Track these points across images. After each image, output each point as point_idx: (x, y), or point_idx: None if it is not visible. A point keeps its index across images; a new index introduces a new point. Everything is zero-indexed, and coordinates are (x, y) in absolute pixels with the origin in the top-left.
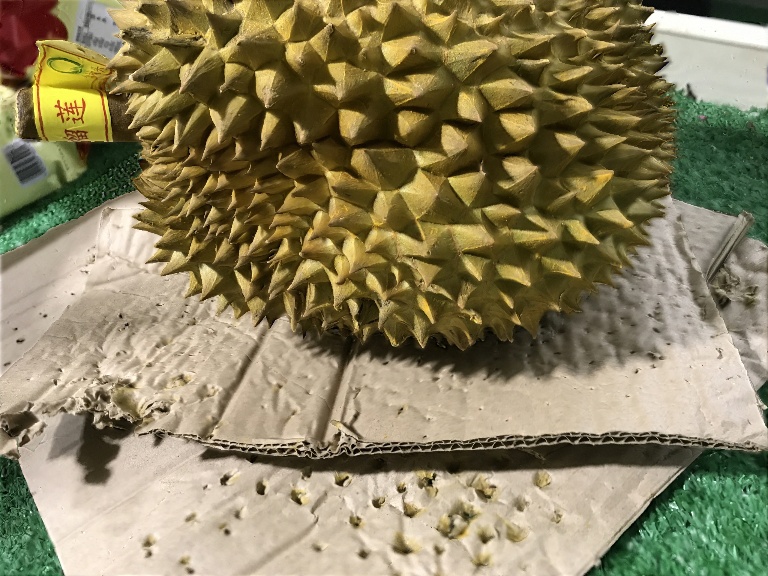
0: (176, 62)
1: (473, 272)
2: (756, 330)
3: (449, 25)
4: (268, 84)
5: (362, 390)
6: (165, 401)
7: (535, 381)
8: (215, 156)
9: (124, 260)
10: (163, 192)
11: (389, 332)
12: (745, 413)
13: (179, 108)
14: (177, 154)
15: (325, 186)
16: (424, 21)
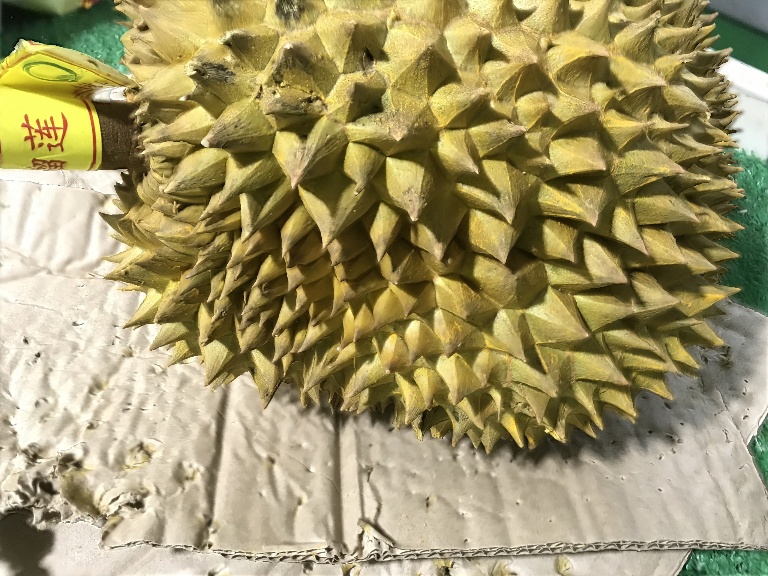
0: (270, 124)
1: (584, 403)
2: (733, 395)
3: (633, 133)
4: (415, 186)
5: (375, 469)
6: (135, 492)
7: (565, 466)
8: (295, 247)
9: (15, 253)
10: (177, 256)
11: (435, 425)
12: (761, 509)
13: (261, 185)
14: (228, 228)
15: (432, 295)
16: (602, 120)
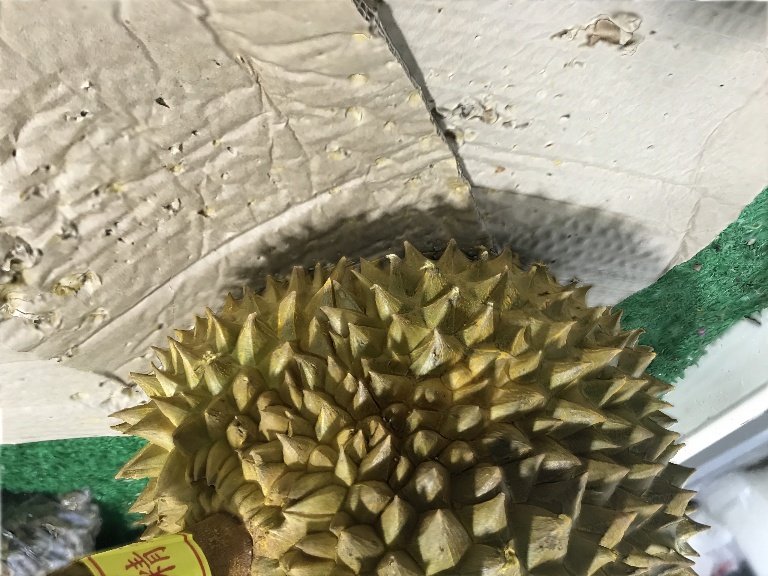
0: None
1: None
2: None
3: None
4: None
5: None
6: (43, 315)
7: None
8: None
9: None
10: None
11: None
12: None
13: None
14: None
15: None
16: None
